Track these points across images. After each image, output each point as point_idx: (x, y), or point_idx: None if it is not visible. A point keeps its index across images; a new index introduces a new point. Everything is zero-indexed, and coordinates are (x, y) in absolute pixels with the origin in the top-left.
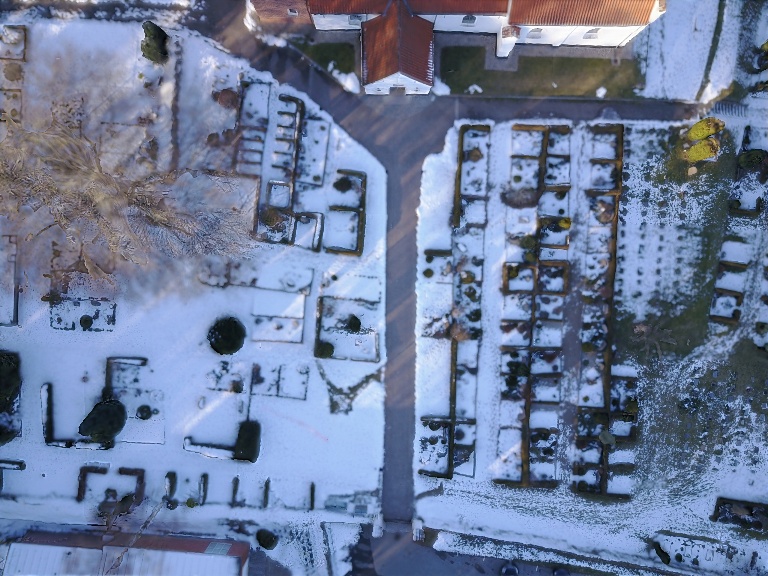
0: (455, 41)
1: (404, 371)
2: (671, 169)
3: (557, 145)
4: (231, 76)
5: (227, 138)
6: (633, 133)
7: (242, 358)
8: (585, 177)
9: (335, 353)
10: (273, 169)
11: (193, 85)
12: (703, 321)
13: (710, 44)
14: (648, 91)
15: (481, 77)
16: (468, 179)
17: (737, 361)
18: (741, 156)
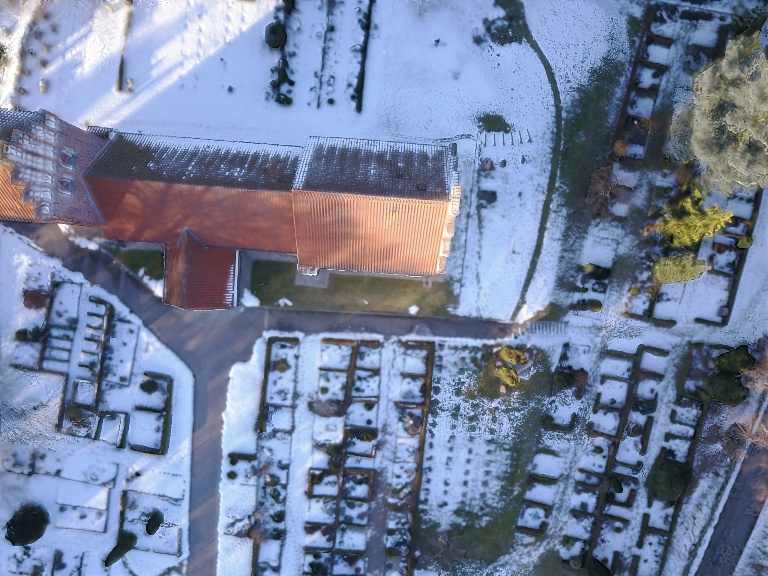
0: (266, 255)
1: (206, 566)
2: (483, 385)
3: (367, 358)
4: (43, 274)
5: (34, 336)
6: (446, 349)
7: (45, 543)
8: (395, 389)
9: (138, 544)
10: (80, 367)
11: (5, 280)
12: (509, 532)
13: (528, 266)
14: (462, 310)
15: (291, 291)
16: (275, 388)
17: (542, 572)
18: (555, 375)
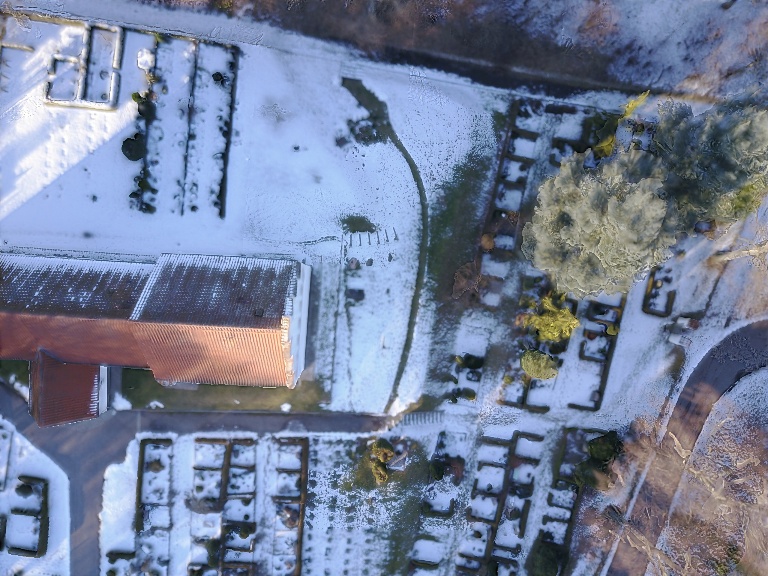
0: None
1: None
2: (358, 477)
3: (242, 456)
4: None
5: None
6: (320, 443)
7: None
8: (271, 484)
9: None
10: None
11: None
12: None
13: (399, 360)
14: (335, 405)
15: (162, 394)
16: (150, 488)
17: None
18: (430, 465)
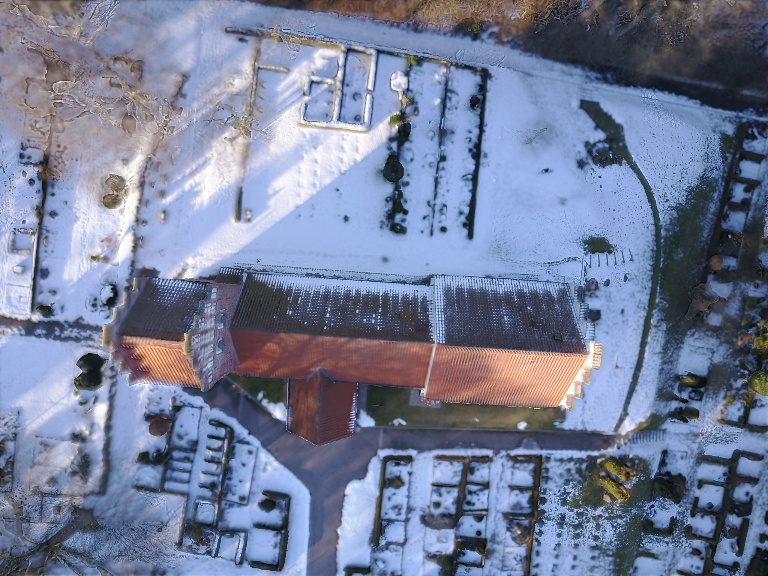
0: None
1: None
2: (587, 495)
3: (477, 472)
4: (164, 399)
5: (156, 460)
6: (552, 461)
7: None
8: (503, 501)
9: None
10: None
11: (126, 405)
12: None
13: (630, 380)
14: (568, 423)
15: (405, 412)
16: (389, 504)
17: None
18: (655, 483)
